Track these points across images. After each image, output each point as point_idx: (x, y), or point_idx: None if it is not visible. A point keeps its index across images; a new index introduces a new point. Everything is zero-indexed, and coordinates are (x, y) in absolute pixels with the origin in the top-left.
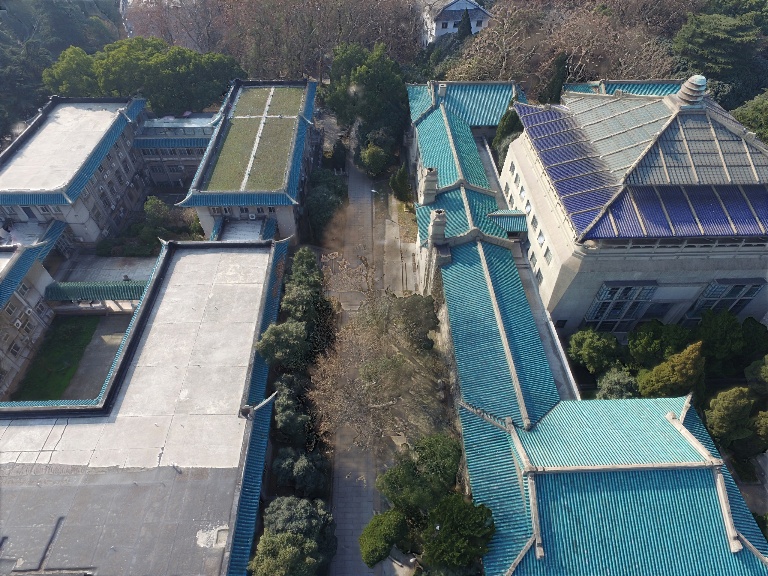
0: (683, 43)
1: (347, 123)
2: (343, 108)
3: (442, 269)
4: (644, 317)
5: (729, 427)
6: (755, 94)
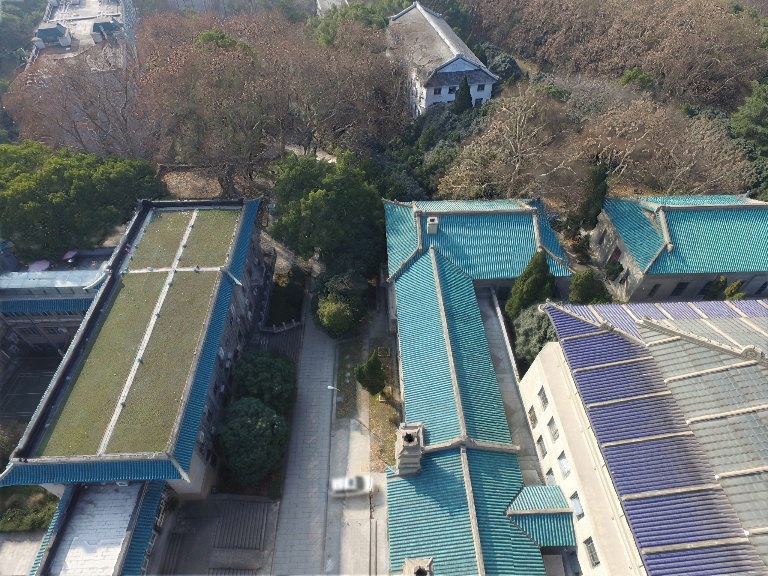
0: (749, 124)
1: None
2: (294, 239)
3: None
4: None
5: None
6: None
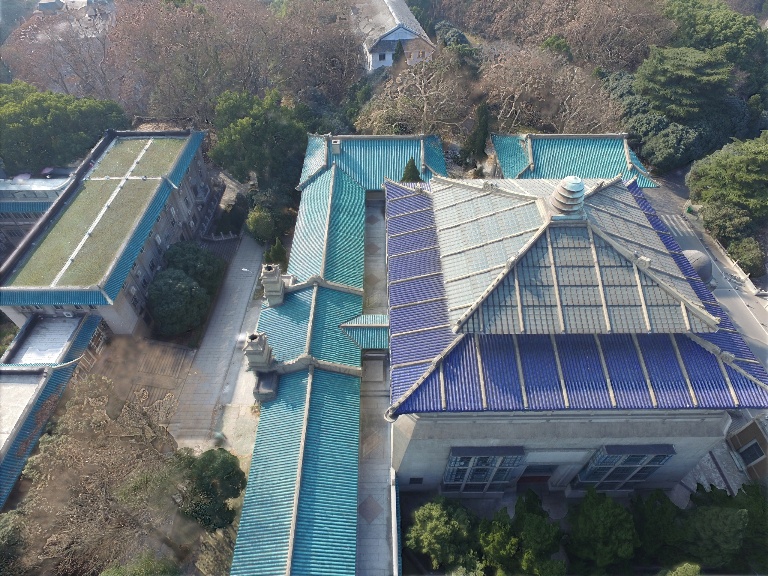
0: (643, 81)
1: None
2: (231, 163)
3: (262, 407)
4: (528, 472)
5: None
6: (728, 139)
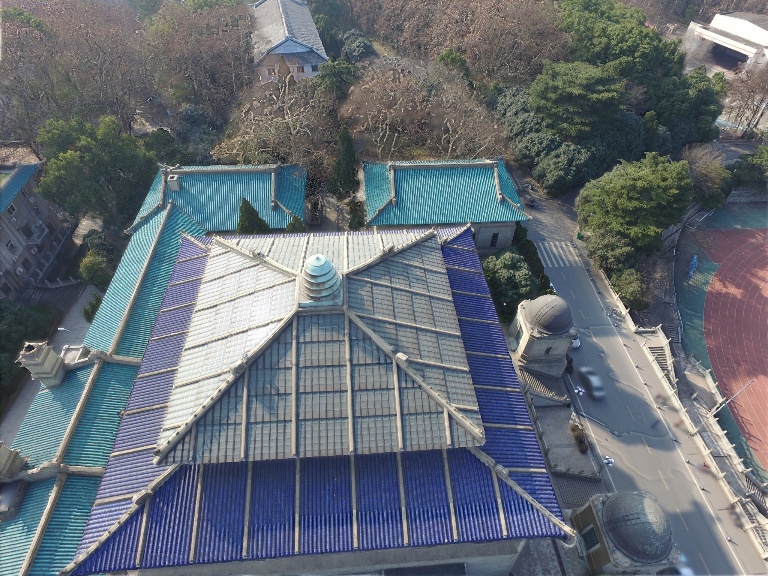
0: (535, 99)
1: (98, 210)
2: (66, 200)
3: None
4: None
5: None
6: (625, 157)
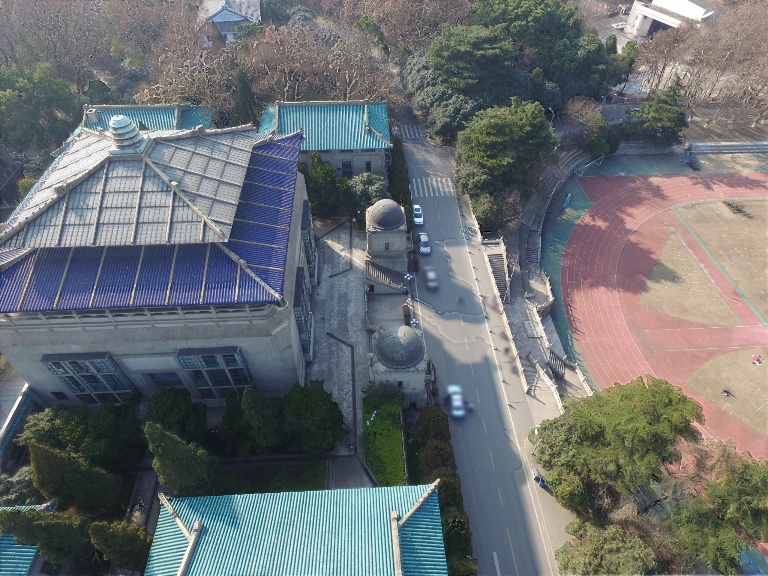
0: (431, 56)
1: None
2: None
3: None
4: None
5: (45, 550)
6: None
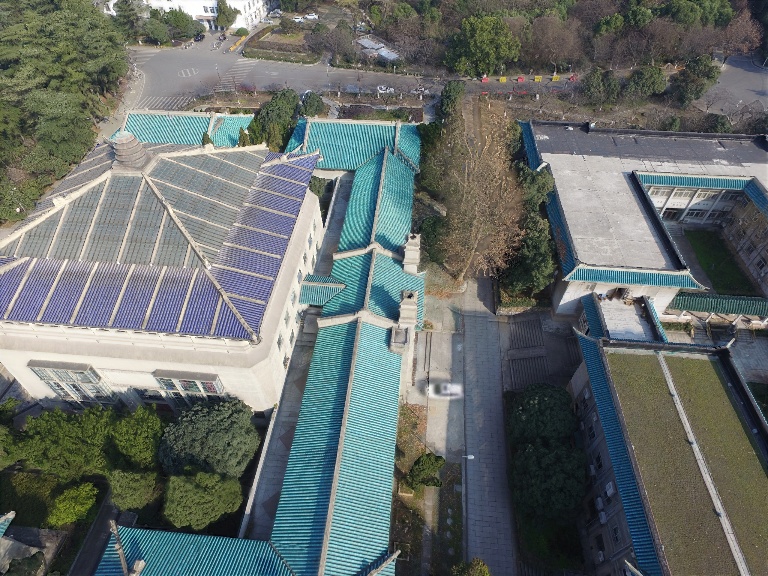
0: None
1: None
2: None
3: None
4: None
5: None
6: None
